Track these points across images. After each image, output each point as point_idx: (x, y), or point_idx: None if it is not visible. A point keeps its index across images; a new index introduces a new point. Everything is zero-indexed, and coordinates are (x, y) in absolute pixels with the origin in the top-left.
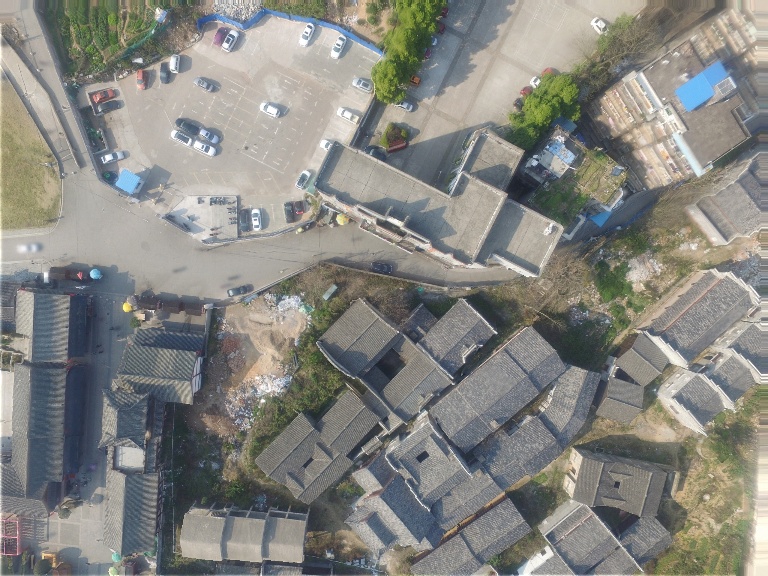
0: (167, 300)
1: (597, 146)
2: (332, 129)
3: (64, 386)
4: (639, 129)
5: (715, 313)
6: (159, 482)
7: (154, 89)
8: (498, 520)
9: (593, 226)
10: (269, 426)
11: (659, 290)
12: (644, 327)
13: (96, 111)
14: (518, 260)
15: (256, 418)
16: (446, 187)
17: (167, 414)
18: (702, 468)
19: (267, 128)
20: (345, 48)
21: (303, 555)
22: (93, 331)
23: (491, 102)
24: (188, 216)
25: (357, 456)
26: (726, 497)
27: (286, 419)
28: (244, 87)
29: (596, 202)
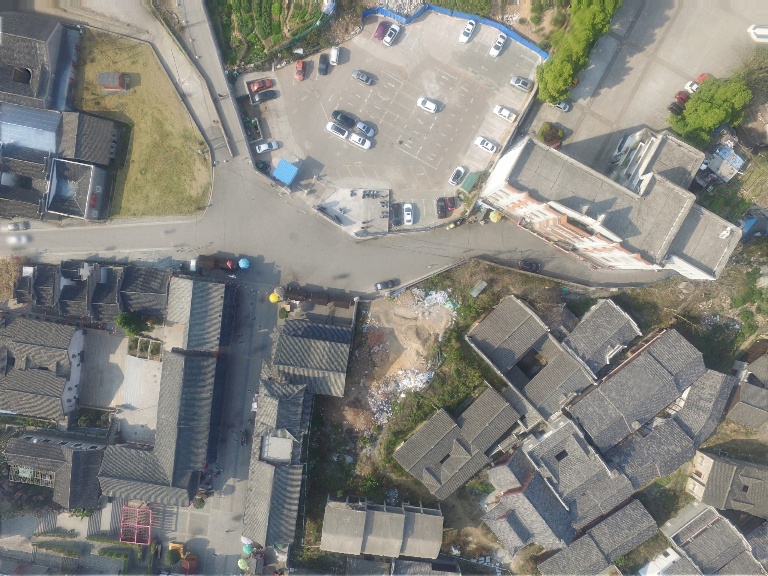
0: (315, 292)
1: (758, 152)
2: (487, 126)
3: (213, 375)
4: None
5: None
6: None
7: (311, 80)
8: (627, 521)
9: None
10: (406, 421)
11: None
12: None
13: (253, 100)
14: (694, 262)
15: (394, 413)
16: (633, 187)
17: None
18: None
19: (422, 123)
20: (504, 46)
21: None
22: (235, 321)
23: (645, 105)
24: (340, 208)
25: (493, 453)
26: None
27: (423, 414)
28: (401, 81)
29: (753, 207)
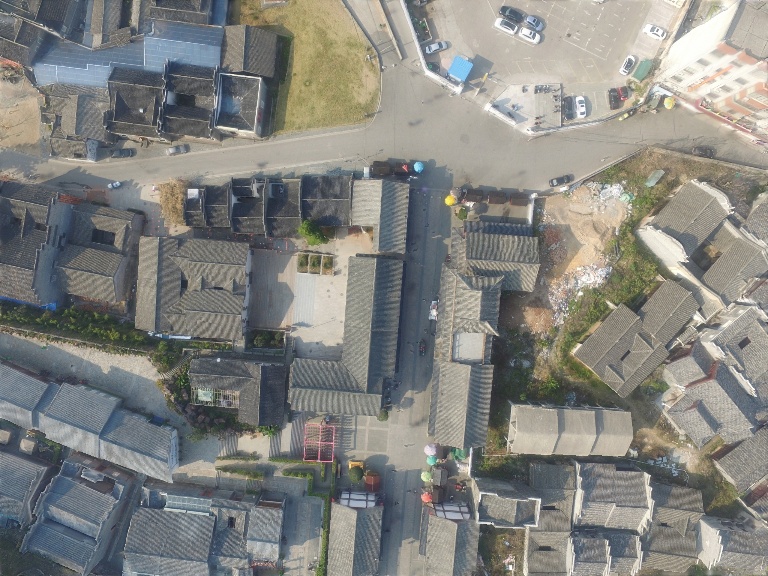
0: (492, 191)
1: None
2: (654, 14)
3: (401, 278)
4: None
5: None
6: None
7: None
8: None
9: None
10: (583, 320)
11: None
12: None
13: (420, 0)
14: None
15: (570, 313)
16: None
17: None
18: None
19: (590, 14)
20: None
21: None
22: None
23: None
24: (513, 105)
25: (671, 348)
26: None
27: (599, 313)
28: None
29: None
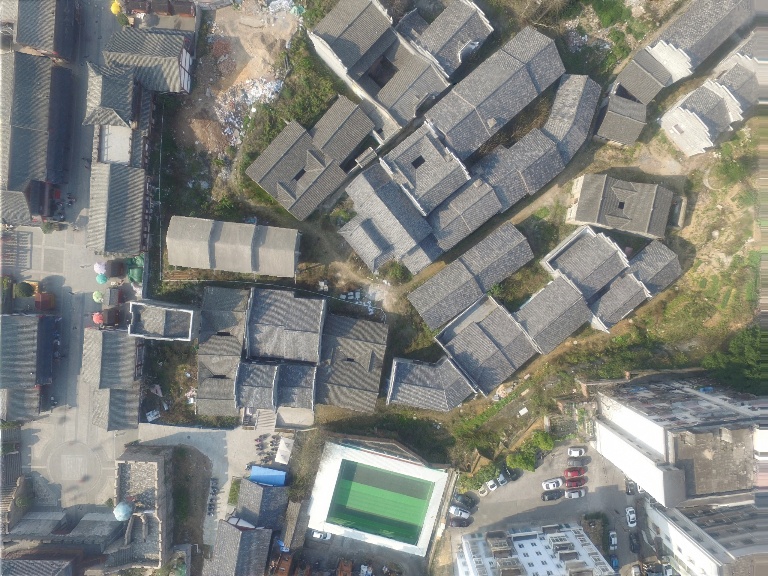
0: None
1: None
2: None
3: (49, 77)
4: None
5: (717, 15)
6: (146, 193)
7: None
8: (498, 242)
9: None
10: (260, 140)
11: (659, 13)
12: None
13: None
14: None
15: (246, 131)
16: None
17: (155, 123)
18: (710, 200)
19: None
20: None
21: None
22: (81, 40)
23: None
24: None
25: (351, 170)
26: (736, 230)
27: (277, 133)
28: None
29: None
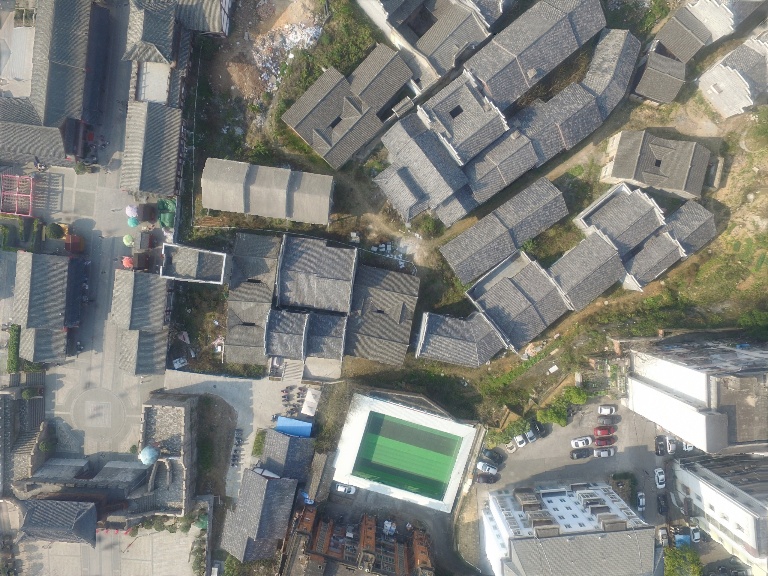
0: None
1: None
2: None
3: (88, 13)
4: None
5: None
6: (181, 136)
7: None
8: (533, 196)
9: None
10: (296, 87)
11: None
12: None
13: None
14: None
15: (283, 77)
16: None
17: (192, 66)
18: (746, 163)
19: None
20: None
21: None
22: None
23: None
24: None
25: (387, 120)
26: None
27: (314, 81)
28: None
29: None
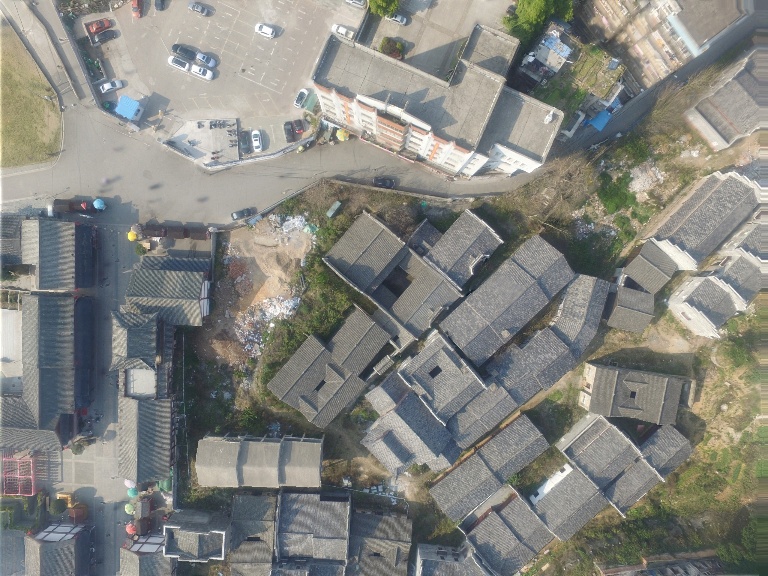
0: (171, 226)
1: (592, 43)
2: None
3: (72, 315)
4: (633, 23)
5: (721, 212)
6: (172, 412)
7: (149, 17)
8: (515, 436)
9: (593, 131)
10: (279, 351)
11: (663, 198)
12: (650, 236)
13: (93, 41)
14: (520, 150)
15: (266, 344)
16: (444, 77)
17: (176, 343)
18: (718, 377)
19: (263, 49)
20: None
21: (320, 480)
22: (99, 264)
23: (484, 12)
24: (189, 141)
25: (369, 377)
26: (744, 405)
27: (296, 344)
28: (238, 10)
29: (595, 100)
